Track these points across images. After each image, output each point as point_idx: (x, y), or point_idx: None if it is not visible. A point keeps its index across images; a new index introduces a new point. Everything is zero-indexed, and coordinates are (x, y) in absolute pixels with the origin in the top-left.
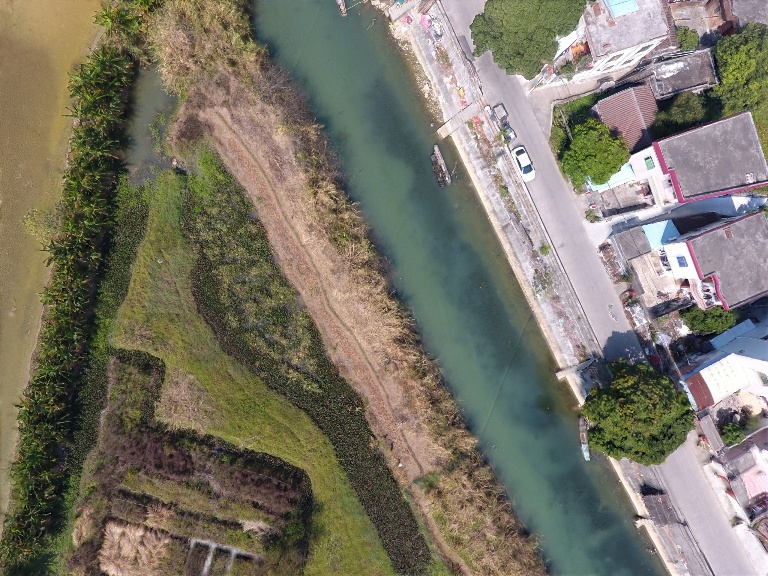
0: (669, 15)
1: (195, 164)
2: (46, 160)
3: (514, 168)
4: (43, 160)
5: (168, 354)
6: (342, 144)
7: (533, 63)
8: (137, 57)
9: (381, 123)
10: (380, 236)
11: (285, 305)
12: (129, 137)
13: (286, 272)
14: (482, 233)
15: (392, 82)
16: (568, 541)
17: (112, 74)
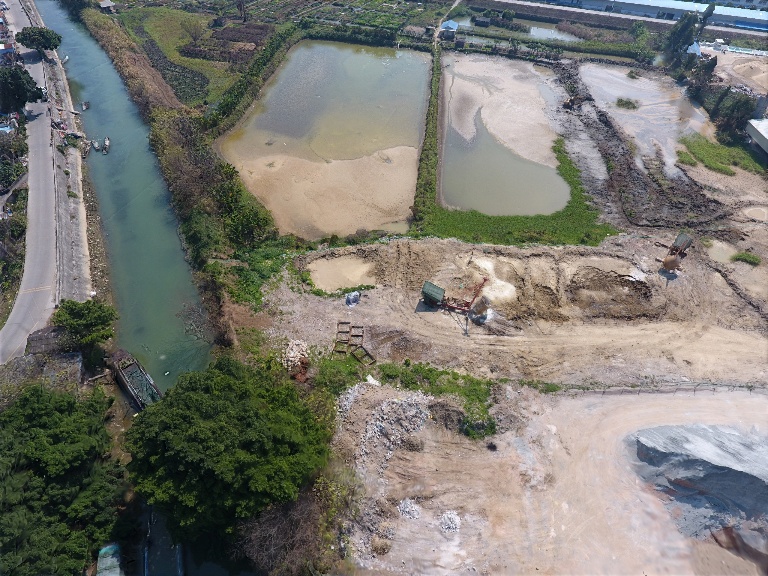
0: None
1: None
2: None
3: None
4: None
5: None
6: None
7: None
8: None
9: None
10: None
11: None
12: None
13: None
14: None
15: (95, 125)
16: (88, 47)
17: None
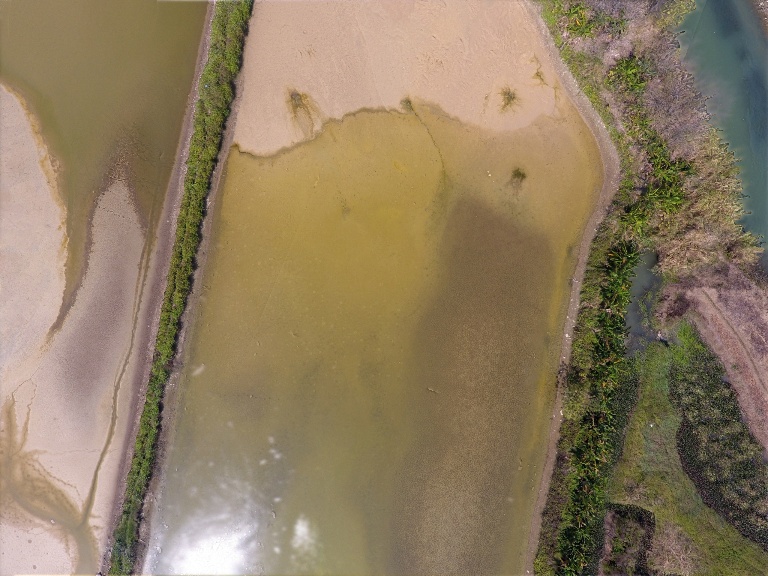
0: None
1: (675, 335)
2: (546, 334)
3: None
4: (544, 334)
5: (660, 508)
6: None
7: None
8: None
9: None
10: None
11: (753, 460)
12: None
13: (755, 431)
14: None
15: None
16: None
17: None
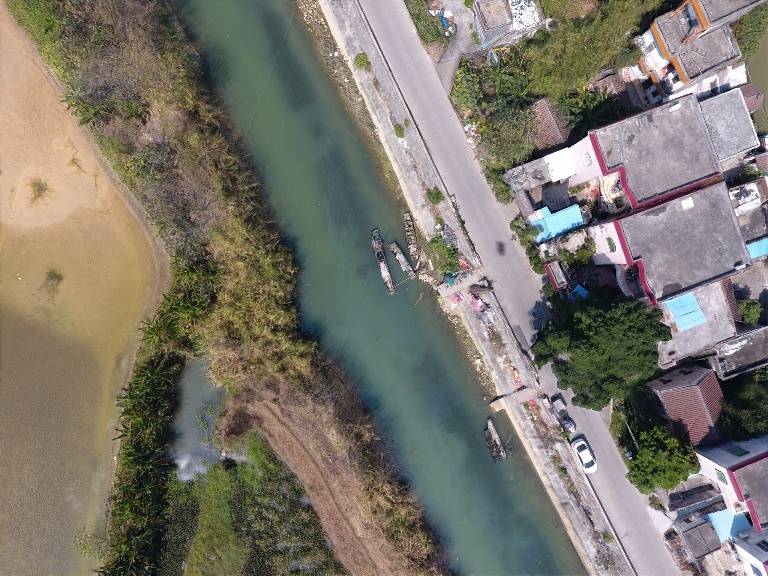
0: (730, 288)
1: (244, 453)
2: (93, 456)
3: (575, 461)
4: (90, 456)
5: None
6: (393, 423)
7: (602, 407)
8: (183, 355)
9: (432, 399)
10: (435, 515)
11: None
12: (177, 431)
13: (340, 559)
14: (539, 505)
15: (442, 355)
16: None
17: (159, 379)
